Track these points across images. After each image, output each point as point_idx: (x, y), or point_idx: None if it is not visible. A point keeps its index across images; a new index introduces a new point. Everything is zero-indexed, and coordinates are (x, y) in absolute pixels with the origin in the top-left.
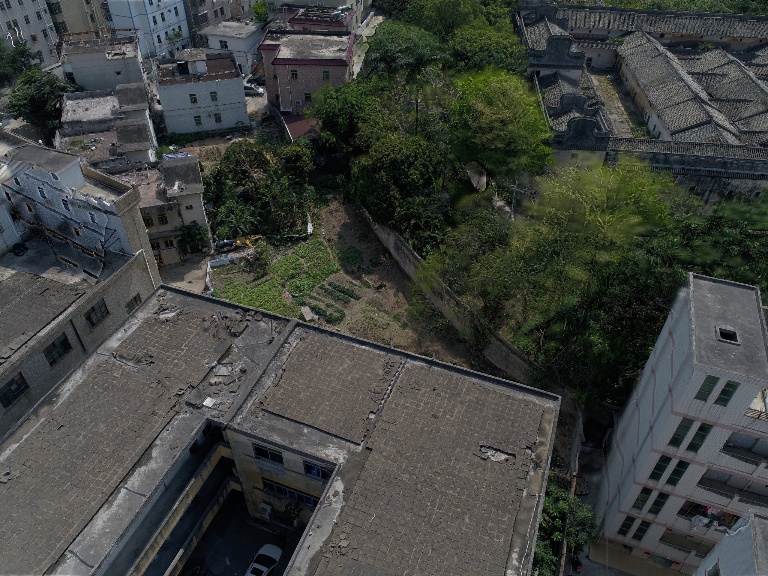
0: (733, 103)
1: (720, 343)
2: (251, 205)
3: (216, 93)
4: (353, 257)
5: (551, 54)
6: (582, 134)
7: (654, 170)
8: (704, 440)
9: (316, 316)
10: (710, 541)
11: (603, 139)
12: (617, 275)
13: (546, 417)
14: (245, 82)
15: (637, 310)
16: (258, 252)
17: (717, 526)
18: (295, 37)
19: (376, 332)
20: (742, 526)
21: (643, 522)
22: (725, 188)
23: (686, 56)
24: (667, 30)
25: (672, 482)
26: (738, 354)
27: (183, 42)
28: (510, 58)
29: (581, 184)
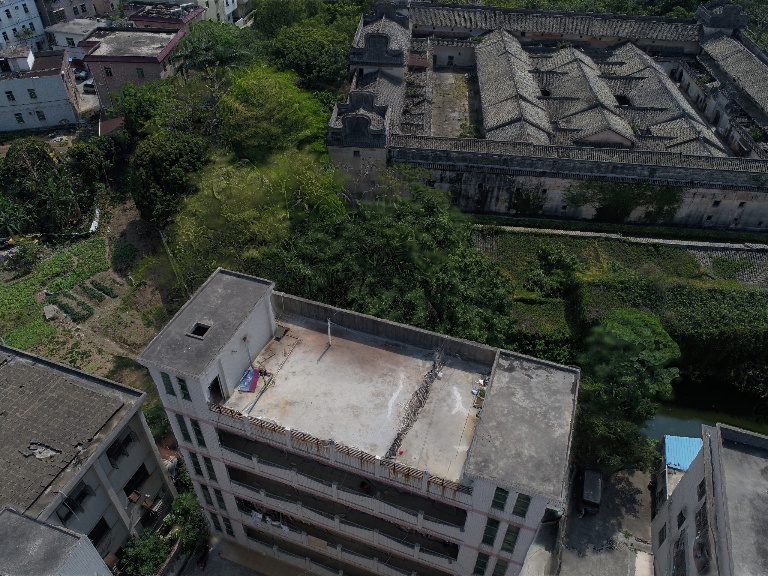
0: (560, 101)
1: (185, 338)
2: (29, 203)
3: (34, 90)
4: (126, 255)
5: (370, 52)
6: (358, 131)
7: (438, 167)
8: (202, 435)
9: (64, 314)
10: (276, 536)
11: (379, 136)
12: (341, 272)
13: (120, 414)
14: (92, 80)
15: (387, 307)
16: (21, 250)
17: (270, 521)
18: (123, 34)
19: (117, 330)
20: (285, 521)
21: (223, 518)
22: (512, 185)
23: (544, 54)
24: (527, 28)
25: (213, 478)
26: (193, 349)
27: (37, 39)
28: (324, 56)
29: (370, 181)
